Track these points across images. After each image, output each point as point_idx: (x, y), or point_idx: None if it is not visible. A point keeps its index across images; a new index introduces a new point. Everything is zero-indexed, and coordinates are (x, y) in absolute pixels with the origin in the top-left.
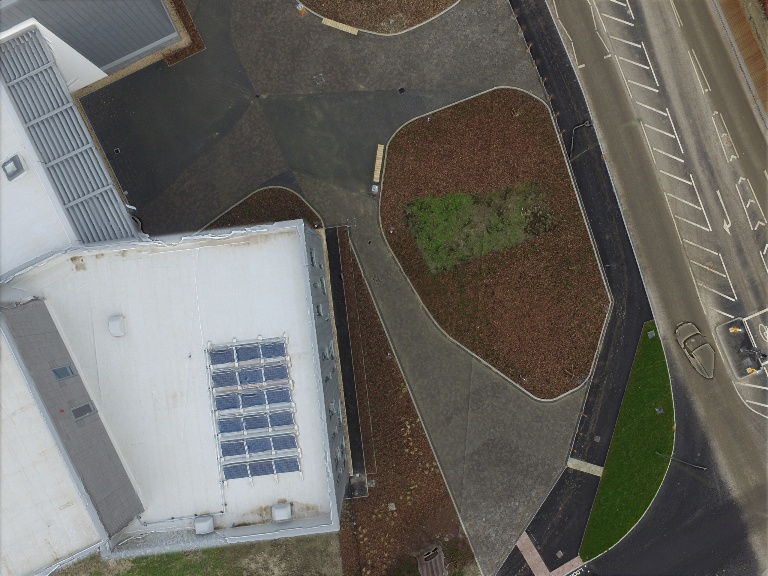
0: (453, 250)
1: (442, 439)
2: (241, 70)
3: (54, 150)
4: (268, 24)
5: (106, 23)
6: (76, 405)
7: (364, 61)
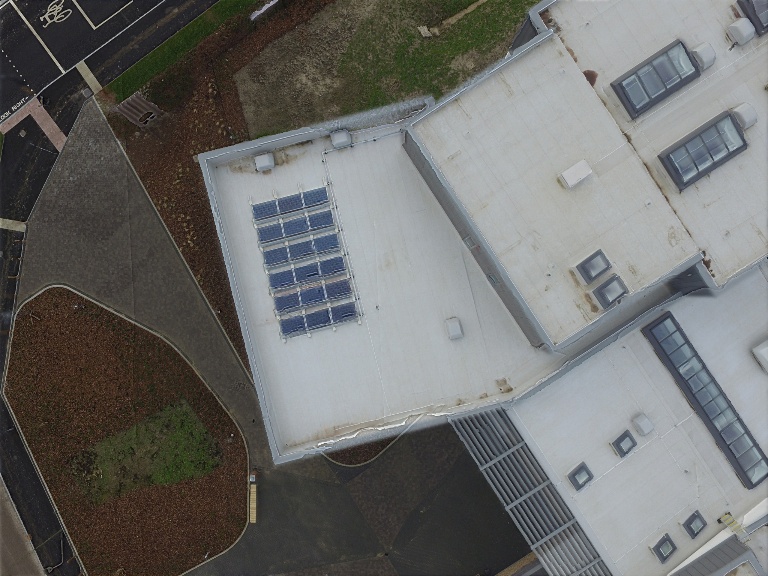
0: (166, 426)
1: (155, 233)
2: None
3: (545, 497)
4: None
5: None
6: (476, 249)
7: None
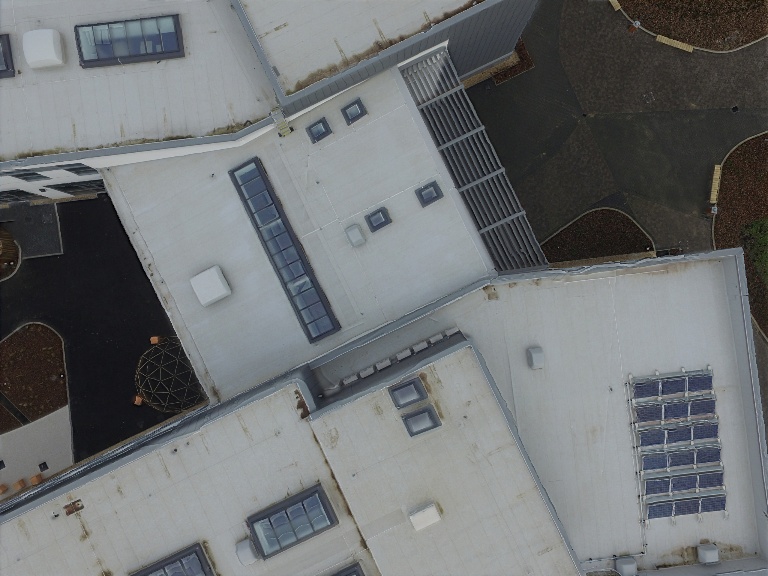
0: None
1: None
2: (569, 89)
3: (463, 175)
4: (597, 42)
5: (484, 43)
6: None
7: (696, 79)
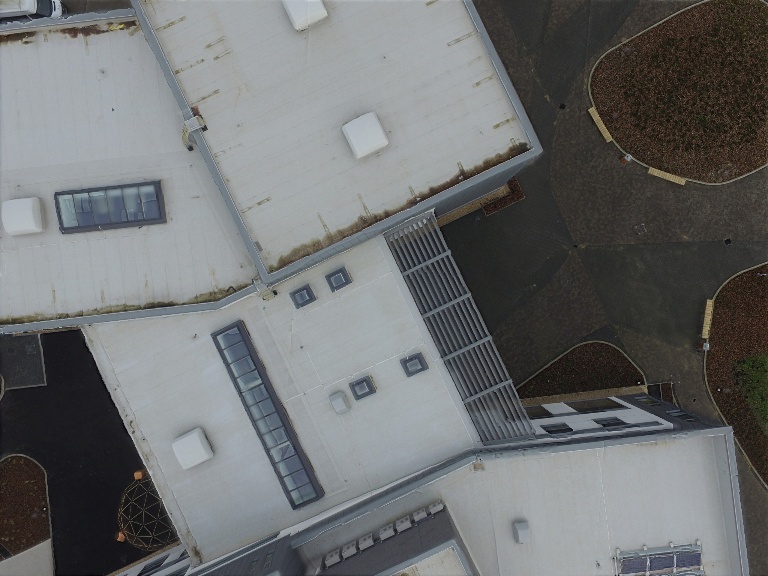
0: None
1: None
2: (560, 219)
3: (449, 342)
4: (589, 172)
5: None
6: None
7: (689, 211)
